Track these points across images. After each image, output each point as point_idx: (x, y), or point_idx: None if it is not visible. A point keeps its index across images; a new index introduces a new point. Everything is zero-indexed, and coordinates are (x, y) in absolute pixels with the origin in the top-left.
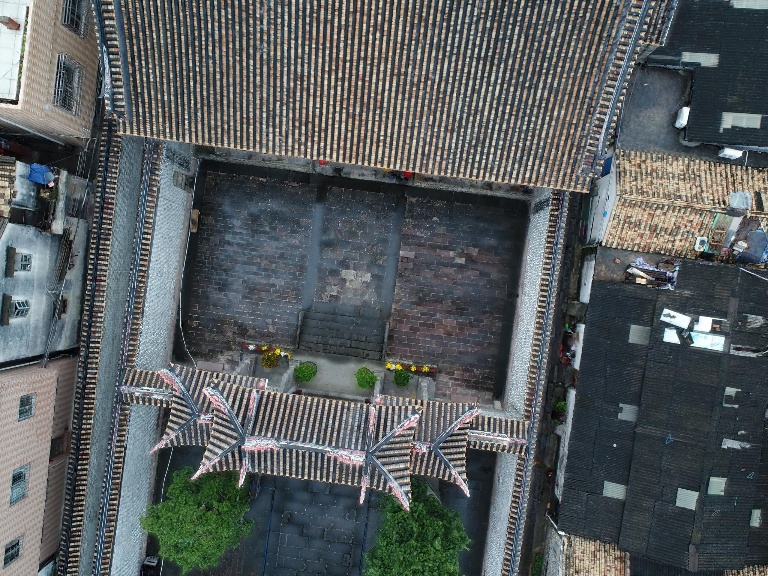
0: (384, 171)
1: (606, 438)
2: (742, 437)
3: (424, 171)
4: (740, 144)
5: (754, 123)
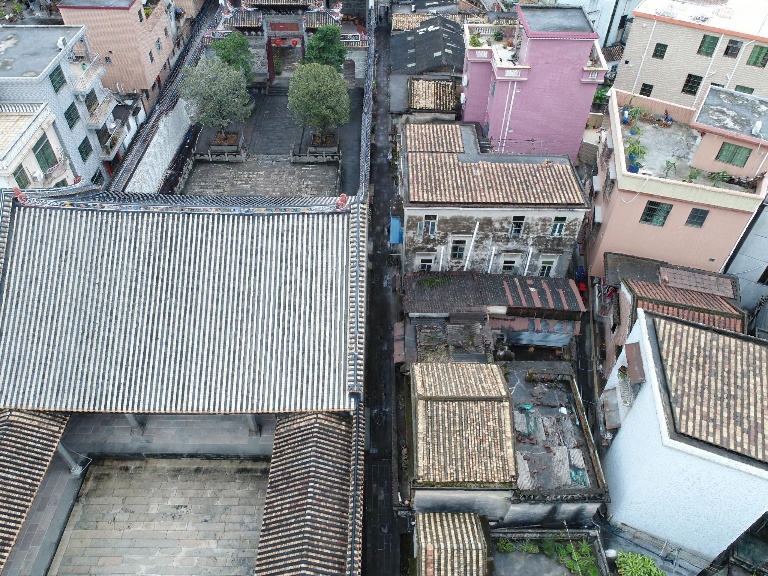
0: None
1: (405, 57)
2: None
3: None
4: (433, 7)
5: (436, 3)
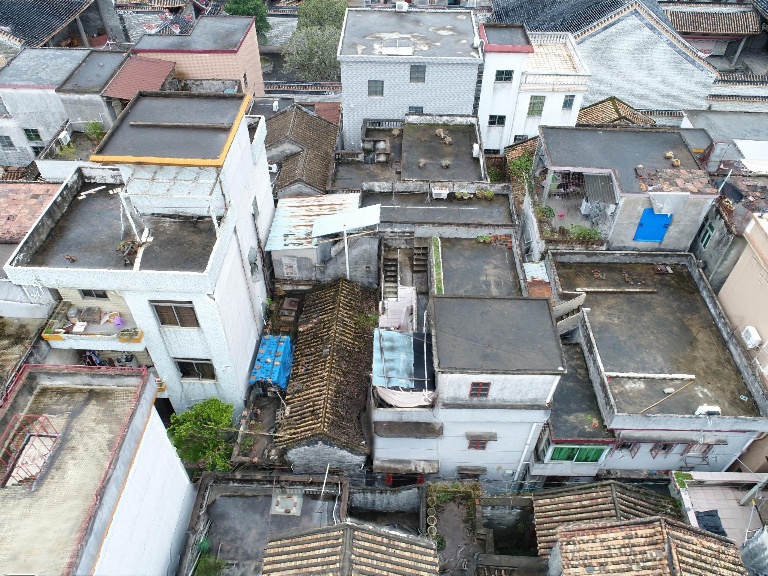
0: None
1: None
2: None
3: (89, 3)
4: None
5: None
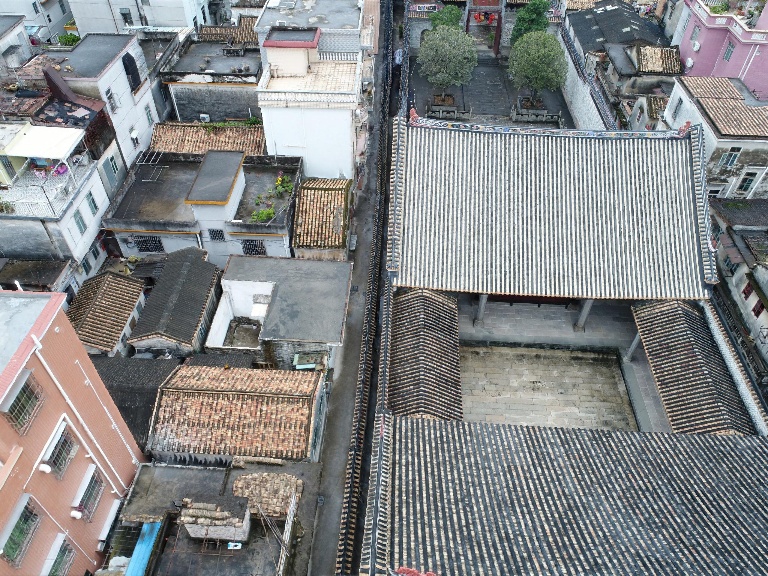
0: None
1: None
2: None
3: None
4: None
5: None
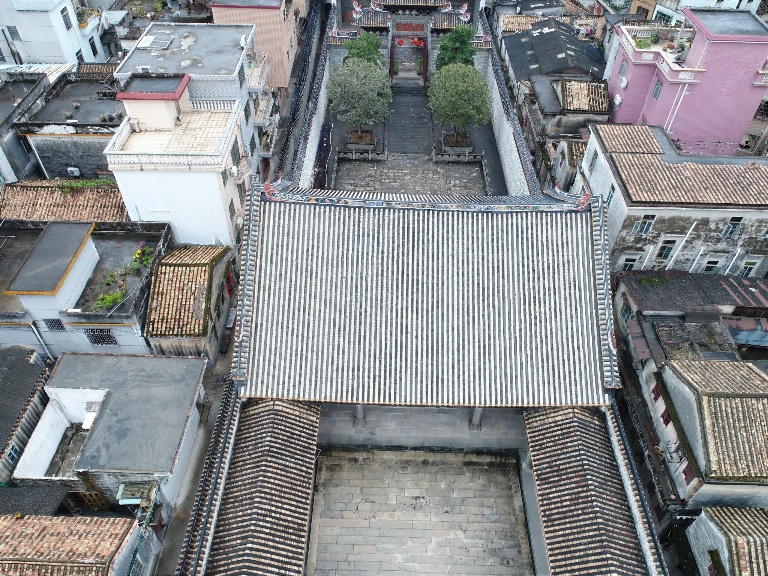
0: (414, 44)
1: None
2: (575, 47)
3: None
4: (539, 8)
5: (542, 5)
